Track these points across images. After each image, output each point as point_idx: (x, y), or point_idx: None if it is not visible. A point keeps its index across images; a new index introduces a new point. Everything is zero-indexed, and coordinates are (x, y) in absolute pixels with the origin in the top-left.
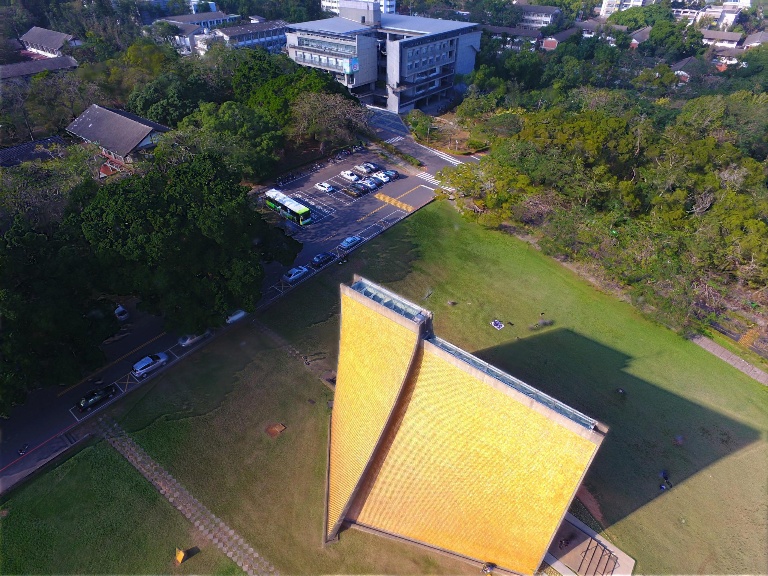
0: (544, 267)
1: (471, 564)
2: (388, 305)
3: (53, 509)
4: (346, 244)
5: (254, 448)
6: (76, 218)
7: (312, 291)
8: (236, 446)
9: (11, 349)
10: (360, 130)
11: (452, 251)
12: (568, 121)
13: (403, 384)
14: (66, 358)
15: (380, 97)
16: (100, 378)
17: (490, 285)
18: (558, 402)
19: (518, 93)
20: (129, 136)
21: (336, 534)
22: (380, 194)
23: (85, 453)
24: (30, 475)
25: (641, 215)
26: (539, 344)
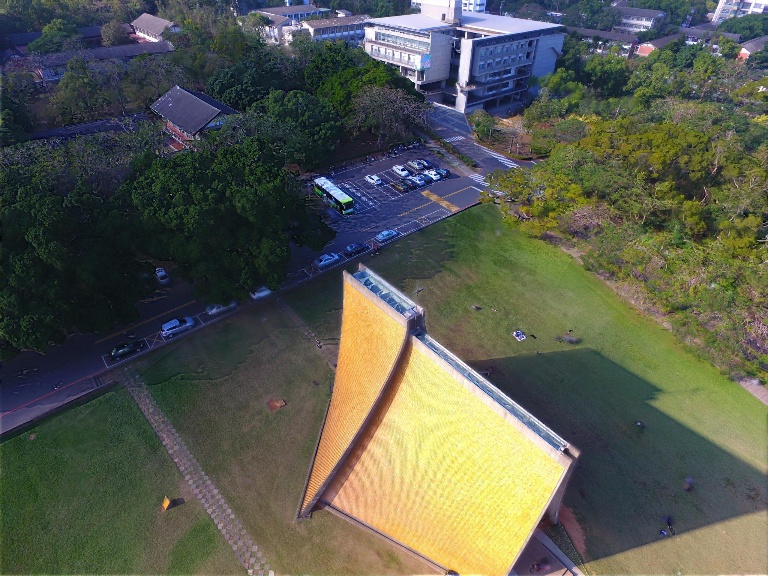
0: (584, 283)
1: (434, 568)
2: (386, 297)
3: (71, 441)
4: (381, 237)
5: (253, 418)
6: (130, 186)
7: (339, 278)
8: (237, 413)
9: (55, 294)
10: (417, 126)
11: (488, 256)
12: (640, 132)
13: (389, 377)
14: (102, 309)
15: (449, 95)
16: (133, 333)
17: (521, 294)
18: (533, 418)
19: (593, 99)
20: (200, 117)
21: (309, 512)
22: (427, 191)
23: (107, 397)
24: (58, 408)
25: (706, 240)
26: (559, 361)
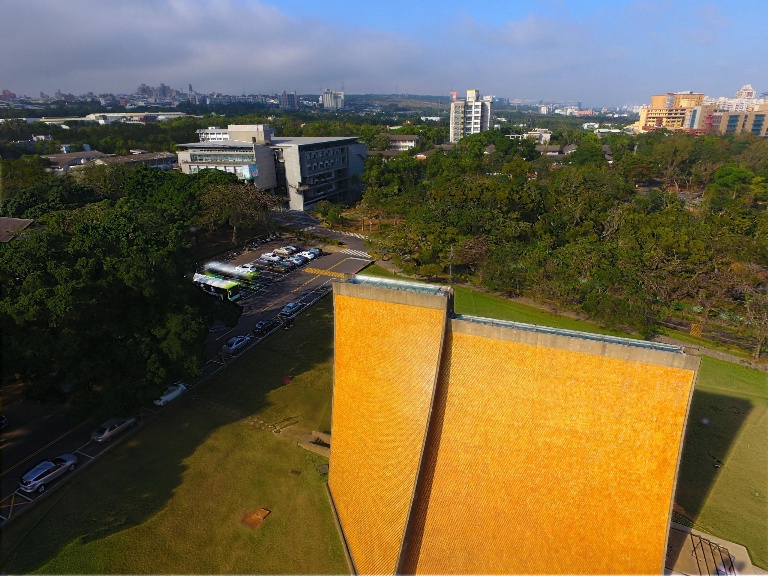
0: (495, 304)
1: None
2: None
3: None
4: (288, 309)
5: (231, 549)
6: None
7: (261, 358)
8: (202, 553)
9: None
10: (276, 214)
11: None
12: None
13: (436, 381)
14: None
15: None
16: None
17: None
18: (630, 340)
19: (413, 182)
20: (0, 232)
21: None
22: (309, 268)
23: None
24: None
25: None
26: None
